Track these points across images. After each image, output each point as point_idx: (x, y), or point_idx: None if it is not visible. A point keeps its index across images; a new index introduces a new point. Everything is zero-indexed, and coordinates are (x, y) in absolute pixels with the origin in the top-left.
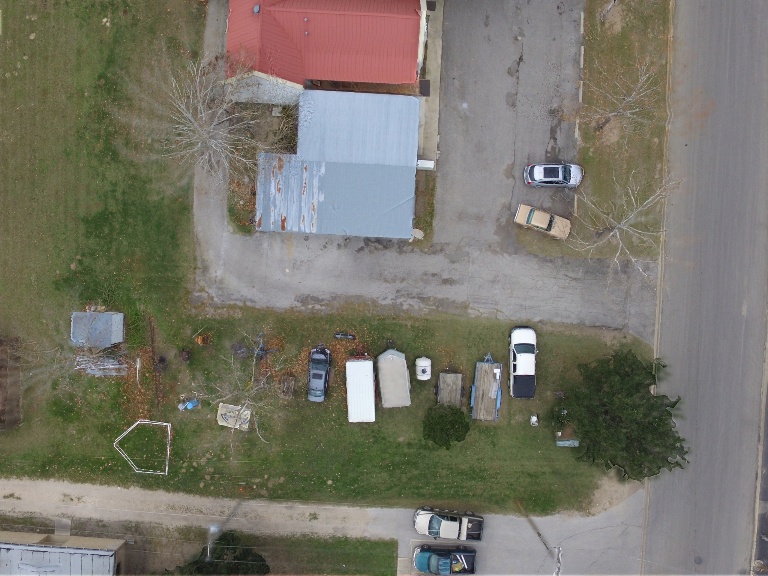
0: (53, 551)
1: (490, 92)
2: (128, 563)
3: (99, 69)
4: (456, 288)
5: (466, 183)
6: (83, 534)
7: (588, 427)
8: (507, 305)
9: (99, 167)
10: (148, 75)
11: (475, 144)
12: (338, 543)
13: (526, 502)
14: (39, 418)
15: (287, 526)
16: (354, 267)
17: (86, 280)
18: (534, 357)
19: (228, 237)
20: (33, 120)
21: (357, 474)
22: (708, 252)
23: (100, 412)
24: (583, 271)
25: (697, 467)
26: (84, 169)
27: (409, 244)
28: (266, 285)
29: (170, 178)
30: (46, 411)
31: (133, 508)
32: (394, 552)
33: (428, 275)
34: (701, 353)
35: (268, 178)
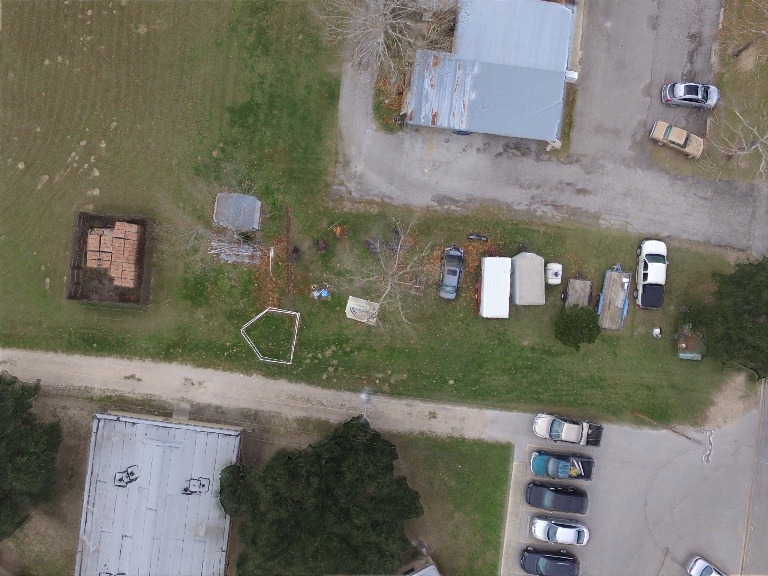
0: (179, 427)
1: (631, 14)
2: (245, 451)
3: None
4: (589, 199)
5: (604, 98)
6: (201, 419)
7: (733, 323)
8: (637, 219)
9: (248, 59)
10: None
11: (615, 62)
12: (456, 444)
13: (643, 415)
14: (168, 300)
15: (406, 423)
16: (491, 171)
17: (226, 167)
18: (665, 267)
19: (370, 134)
20: (186, 10)
21: (479, 375)
22: None
23: (230, 298)
24: (712, 191)
25: None
26: (233, 60)
27: (546, 153)
28: (404, 183)
29: (318, 74)
30: (176, 294)
31: (254, 396)
32: (510, 456)
33: (563, 184)
34: None
35: (422, 74)
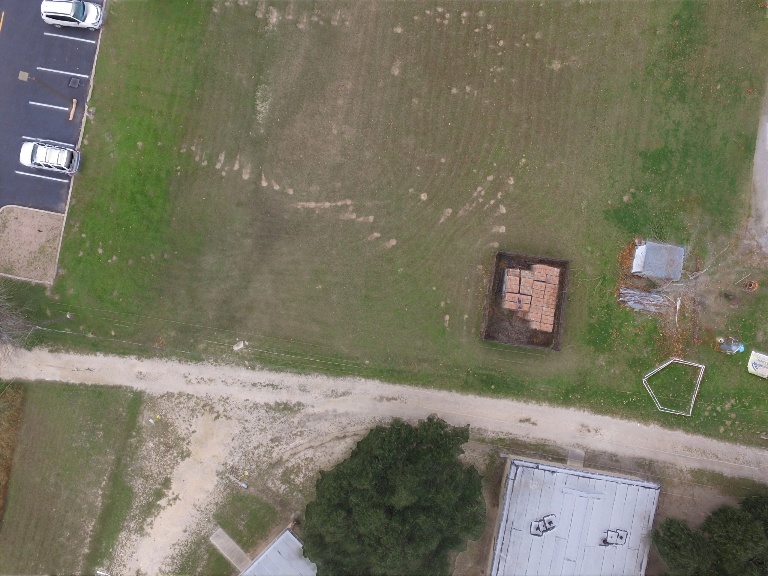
0: (600, 478)
1: None
2: None
3: (674, 10)
4: None
5: None
6: (596, 467)
7: None
8: None
9: (663, 105)
10: (724, 23)
11: None
12: None
13: None
14: (571, 345)
15: None
16: None
17: (637, 214)
18: None
19: None
20: (602, 49)
21: None
22: None
23: (633, 346)
24: None
25: None
26: (648, 105)
27: None
28: None
29: (735, 126)
30: (579, 339)
31: (650, 446)
32: None
33: None
34: None
35: None
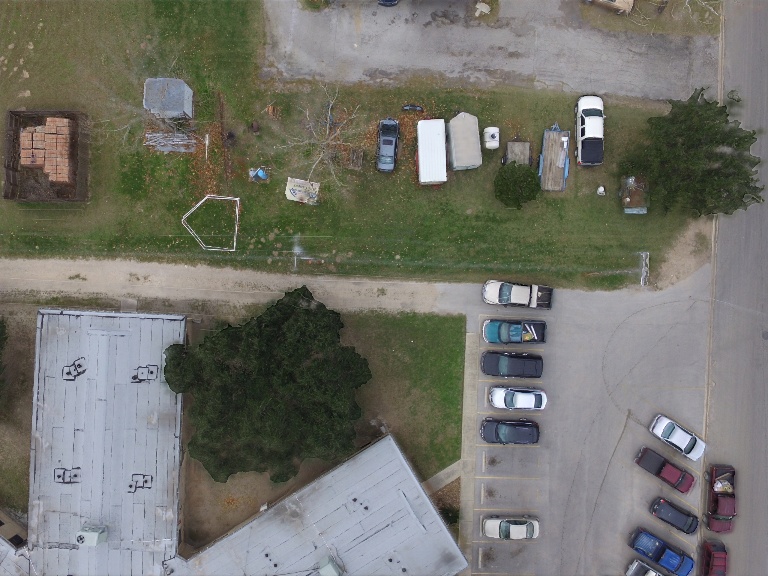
0: (123, 316)
1: None
2: (194, 342)
3: None
4: (522, 61)
5: None
6: None
7: (667, 154)
8: (573, 78)
9: None
10: None
11: None
12: (406, 319)
13: (594, 276)
14: (107, 196)
15: (355, 302)
16: (422, 41)
17: (156, 59)
18: (602, 120)
19: (297, 13)
20: None
21: (425, 248)
22: (767, 30)
23: (168, 189)
24: (646, 46)
25: (762, 241)
26: None
27: (476, 18)
28: (335, 59)
29: None
30: (114, 189)
31: (200, 286)
32: (462, 327)
33: (495, 48)
34: (763, 128)
35: None
